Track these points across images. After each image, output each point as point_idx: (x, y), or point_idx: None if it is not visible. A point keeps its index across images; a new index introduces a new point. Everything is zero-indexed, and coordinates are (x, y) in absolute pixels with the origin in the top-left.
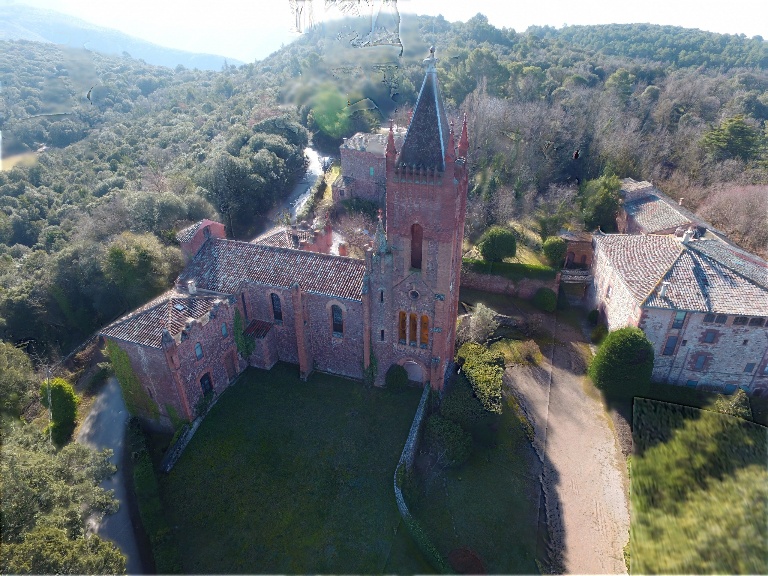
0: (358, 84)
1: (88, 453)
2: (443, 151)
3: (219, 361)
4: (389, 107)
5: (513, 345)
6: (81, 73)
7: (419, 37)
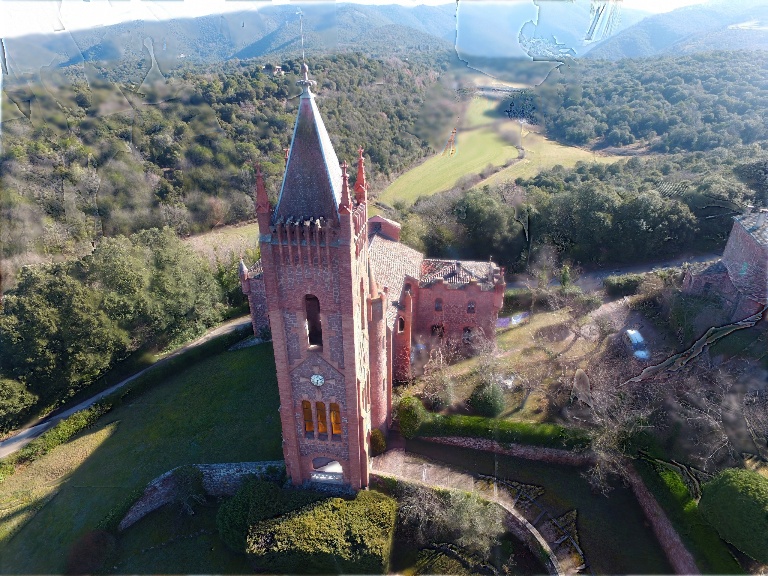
0: (475, 111)
1: (189, 298)
2: None
3: None
4: (494, 148)
5: None
6: (545, 83)
7: (457, 47)
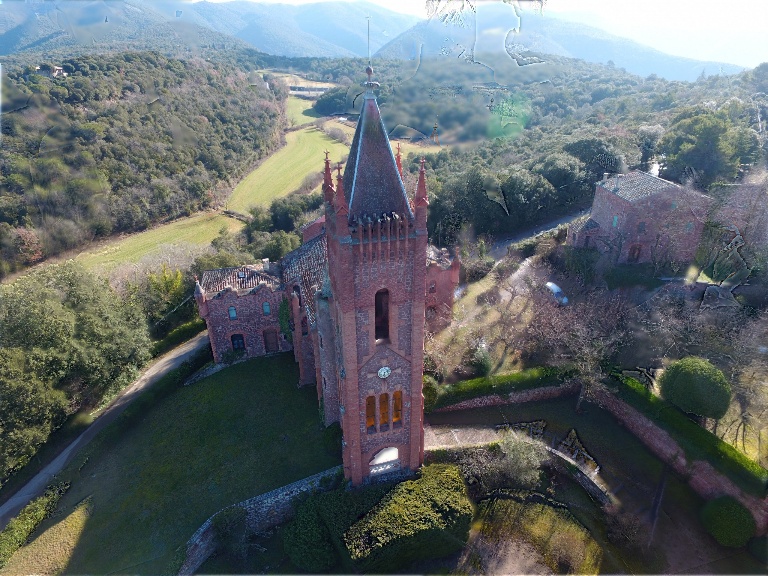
0: (454, 107)
1: (127, 338)
2: (351, 199)
3: (256, 331)
4: (483, 139)
5: (567, 528)
6: None
7: (476, 51)
